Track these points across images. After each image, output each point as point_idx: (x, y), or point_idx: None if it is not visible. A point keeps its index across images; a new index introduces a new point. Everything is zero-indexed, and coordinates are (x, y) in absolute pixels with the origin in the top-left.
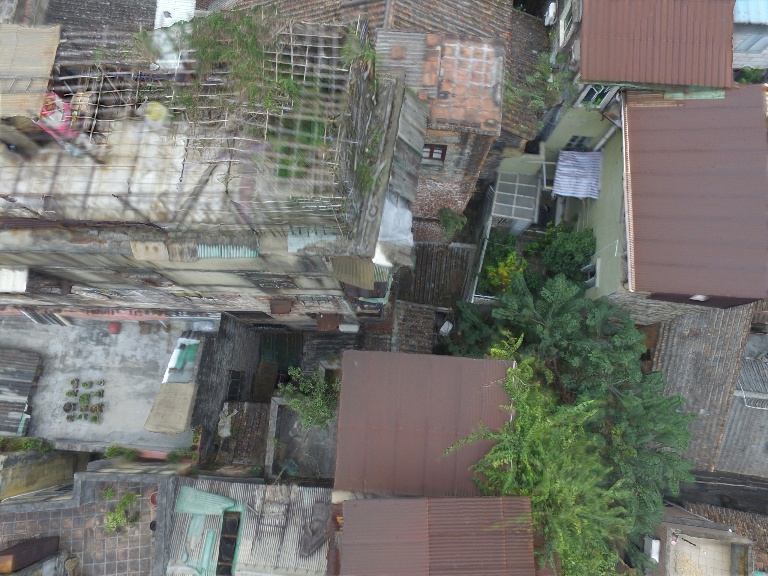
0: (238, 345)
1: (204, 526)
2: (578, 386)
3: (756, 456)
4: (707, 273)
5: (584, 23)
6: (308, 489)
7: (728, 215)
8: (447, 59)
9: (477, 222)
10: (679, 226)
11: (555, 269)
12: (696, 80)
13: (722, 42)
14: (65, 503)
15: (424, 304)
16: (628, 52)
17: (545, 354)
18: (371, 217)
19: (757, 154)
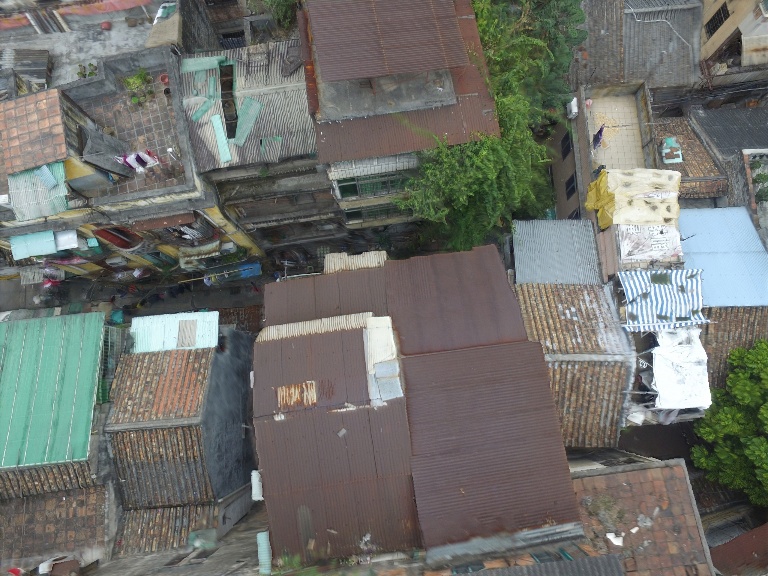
0: (213, 42)
1: (206, 76)
2: None
3: (655, 68)
4: None
5: None
6: (282, 42)
7: None
8: None
9: None
10: None
11: None
12: None
13: None
14: (93, 77)
15: None
16: None
17: None
18: None
19: None
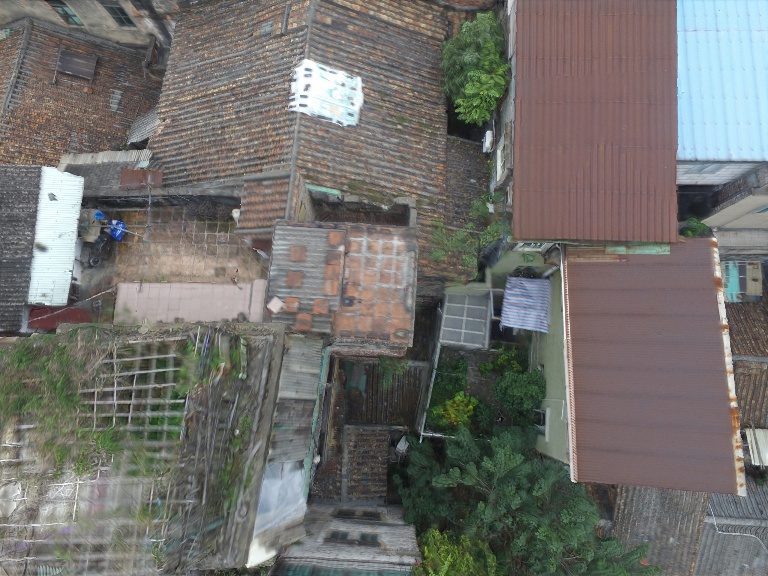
0: None
1: None
2: (529, 556)
3: None
4: (655, 461)
5: (515, 175)
6: None
7: (676, 392)
8: (353, 257)
9: (430, 333)
10: (624, 404)
11: (506, 407)
12: (638, 235)
13: (665, 192)
14: None
15: (377, 425)
16: (564, 206)
17: (489, 531)
18: (241, 518)
19: (706, 320)
